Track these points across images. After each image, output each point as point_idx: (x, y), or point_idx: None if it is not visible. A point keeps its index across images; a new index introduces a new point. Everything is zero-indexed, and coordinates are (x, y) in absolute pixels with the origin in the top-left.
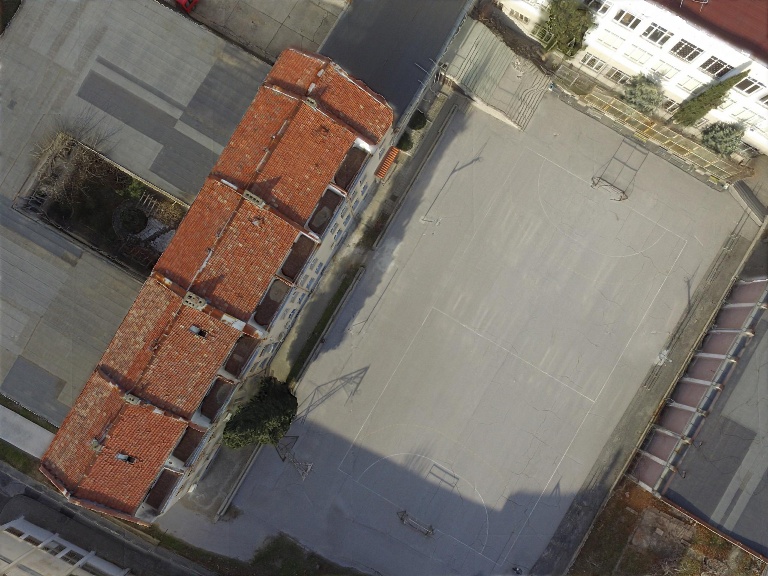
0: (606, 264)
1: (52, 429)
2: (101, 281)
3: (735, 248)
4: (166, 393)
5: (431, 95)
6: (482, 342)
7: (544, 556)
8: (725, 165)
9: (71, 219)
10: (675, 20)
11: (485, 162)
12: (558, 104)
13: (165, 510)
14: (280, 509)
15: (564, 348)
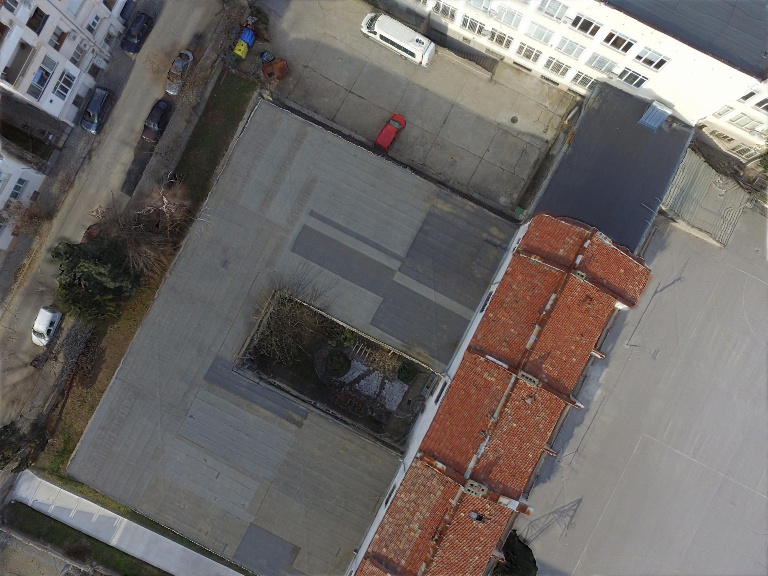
0: None
1: None
2: (329, 441)
3: None
4: None
5: None
6: (696, 467)
7: None
8: None
9: (274, 366)
10: None
11: (687, 282)
12: (758, 218)
13: None
14: None
15: None
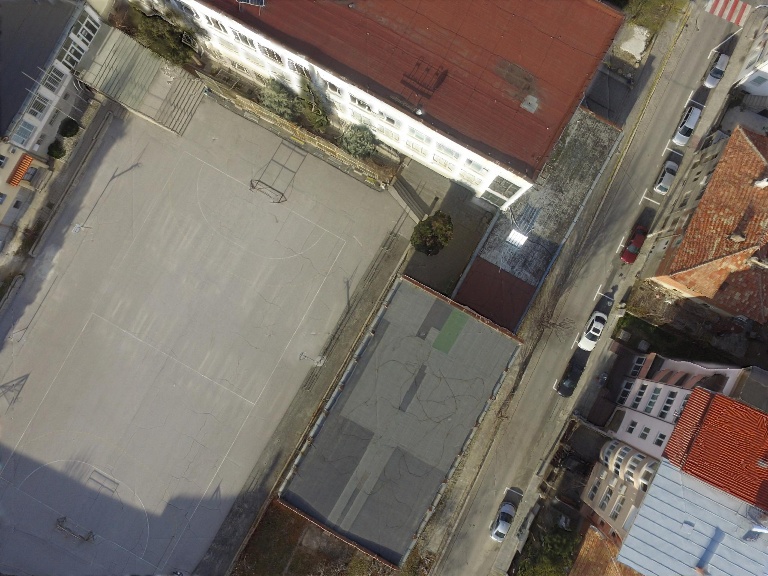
0: (266, 266)
1: None
2: None
3: (395, 247)
4: None
5: (81, 102)
6: (142, 347)
7: (205, 559)
8: (365, 165)
9: None
10: (235, 24)
11: (144, 167)
12: (216, 108)
13: None
14: None
15: (224, 351)
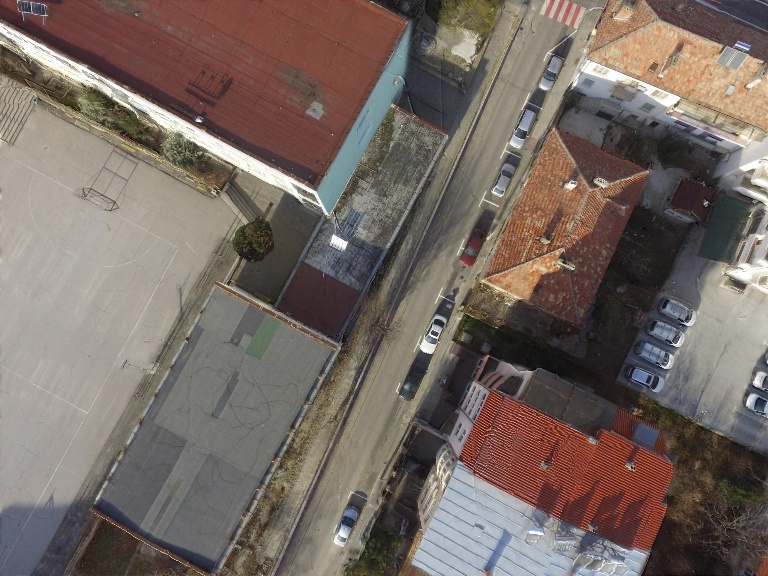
0: (98, 274)
1: None
2: None
3: (227, 254)
4: None
5: None
6: None
7: (39, 569)
8: None
9: None
10: (19, 34)
11: None
12: (48, 117)
13: None
14: None
15: (56, 360)
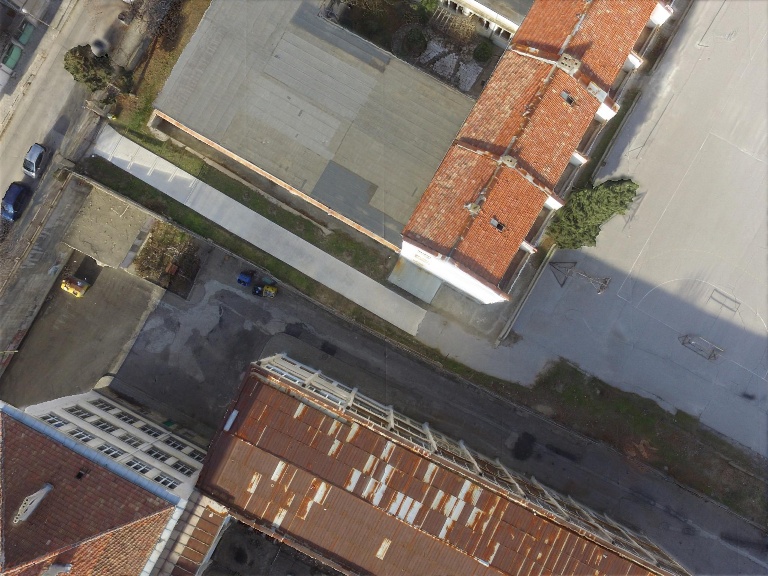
0: None
1: (333, 253)
2: (410, 87)
3: None
4: (535, 160)
5: None
6: (761, 166)
7: None
8: None
9: None
10: None
11: None
12: None
13: None
14: (559, 335)
15: None
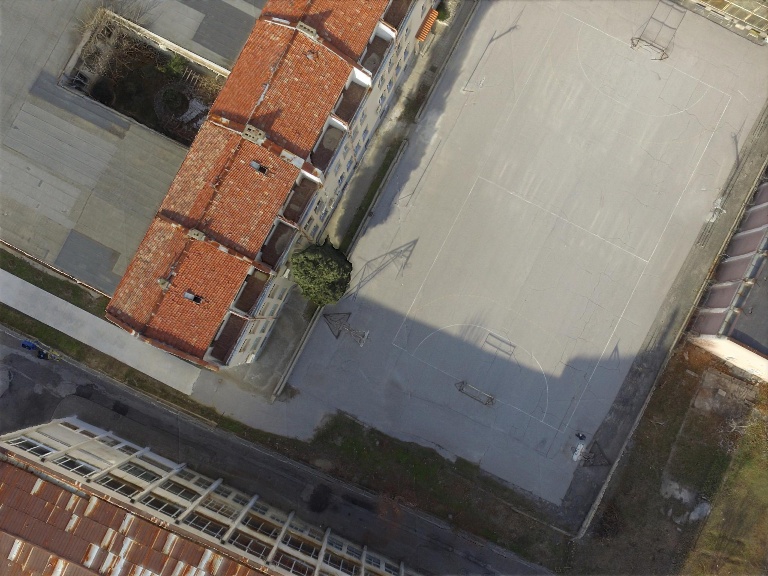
0: (651, 124)
1: (104, 317)
2: (150, 152)
3: None
4: (229, 231)
5: None
6: (530, 208)
7: (607, 421)
8: (767, 11)
9: (113, 106)
10: None
11: (523, 29)
12: None
13: (230, 363)
14: (336, 387)
15: (614, 210)
